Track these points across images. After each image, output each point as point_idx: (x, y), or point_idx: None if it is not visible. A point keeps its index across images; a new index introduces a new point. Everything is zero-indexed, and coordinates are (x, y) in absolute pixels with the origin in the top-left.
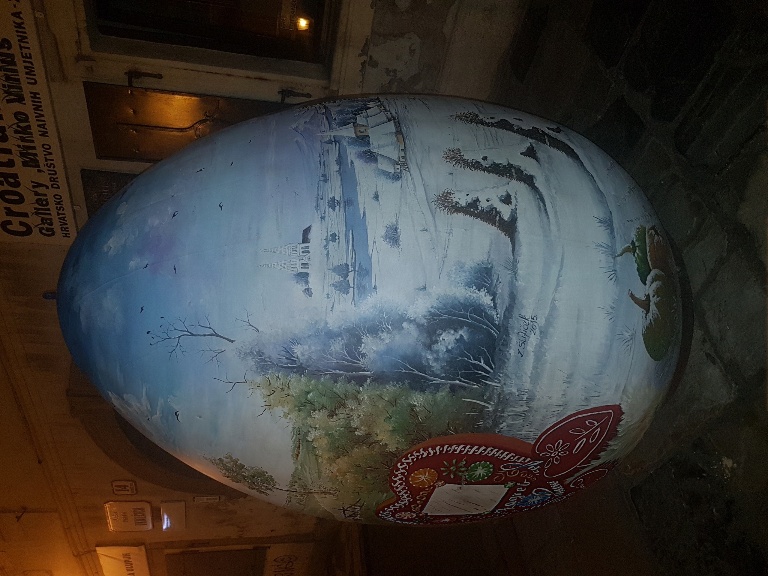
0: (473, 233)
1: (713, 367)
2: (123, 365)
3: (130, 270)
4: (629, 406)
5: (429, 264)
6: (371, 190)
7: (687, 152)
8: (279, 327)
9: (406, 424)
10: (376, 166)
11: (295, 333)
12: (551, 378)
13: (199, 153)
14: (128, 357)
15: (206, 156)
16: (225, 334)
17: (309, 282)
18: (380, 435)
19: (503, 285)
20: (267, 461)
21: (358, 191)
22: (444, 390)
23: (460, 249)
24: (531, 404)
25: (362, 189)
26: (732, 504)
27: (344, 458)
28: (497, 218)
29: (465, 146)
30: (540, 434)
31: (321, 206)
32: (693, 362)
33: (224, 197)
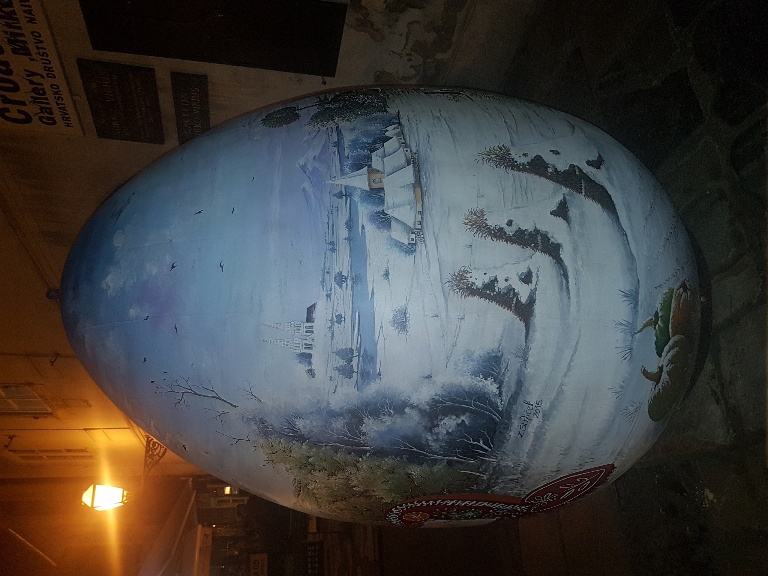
0: (486, 319)
1: (716, 406)
2: (130, 398)
3: (131, 318)
4: (622, 462)
5: (437, 352)
6: (382, 266)
7: (741, 171)
8: (281, 401)
9: (402, 486)
10: (389, 234)
11: (297, 408)
12: (548, 452)
13: (198, 181)
14: (135, 393)
15: (205, 190)
16: (228, 399)
17: (312, 363)
18: (377, 492)
19: (511, 373)
20: (270, 492)
21: (367, 266)
22: (441, 464)
23: (471, 337)
24: (525, 473)
25: (372, 264)
26: (704, 531)
27: (342, 502)
28: (514, 301)
29: (489, 206)
30: (531, 491)
31: (327, 282)
32: (697, 391)
33: (225, 255)
